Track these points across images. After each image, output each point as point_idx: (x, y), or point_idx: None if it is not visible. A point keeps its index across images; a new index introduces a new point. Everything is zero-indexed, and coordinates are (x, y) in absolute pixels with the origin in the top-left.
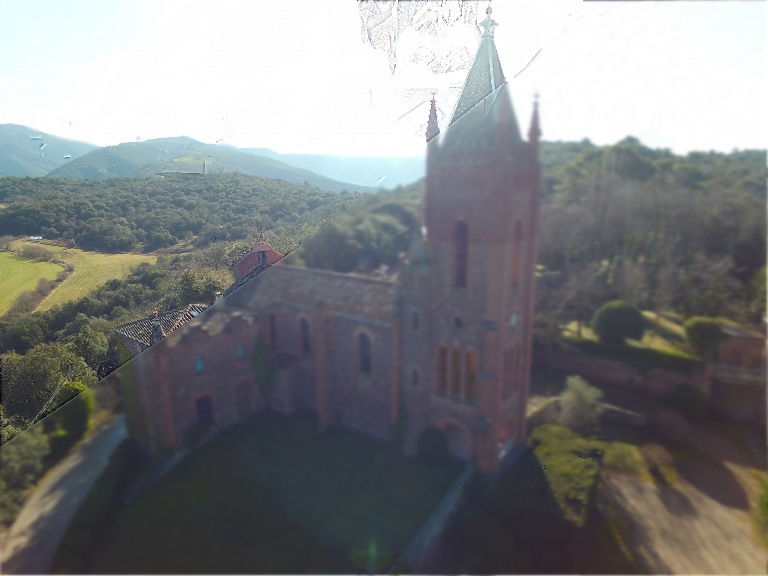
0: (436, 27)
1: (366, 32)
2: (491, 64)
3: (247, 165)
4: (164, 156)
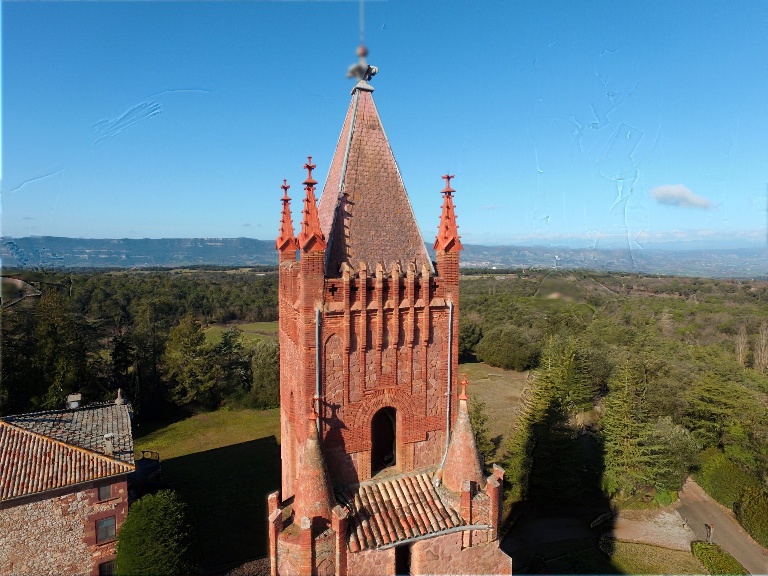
0: None
1: None
2: None
3: None
4: None
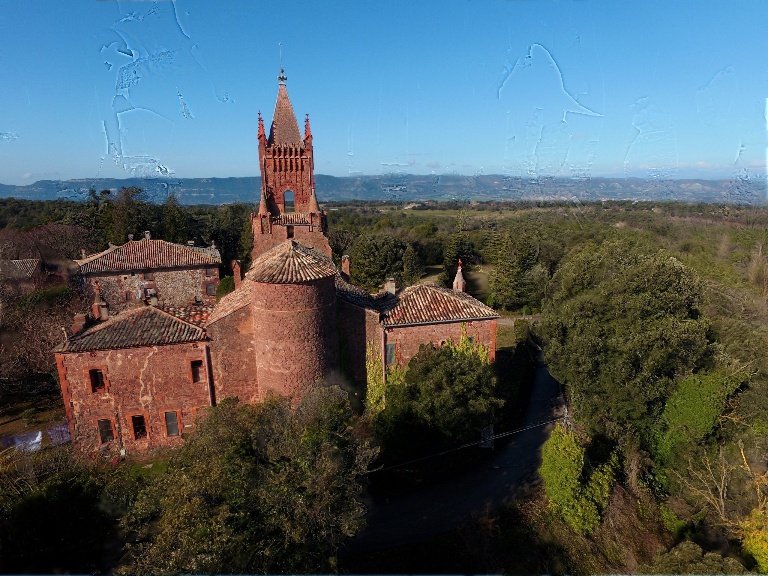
0: None
1: None
2: None
3: None
4: None
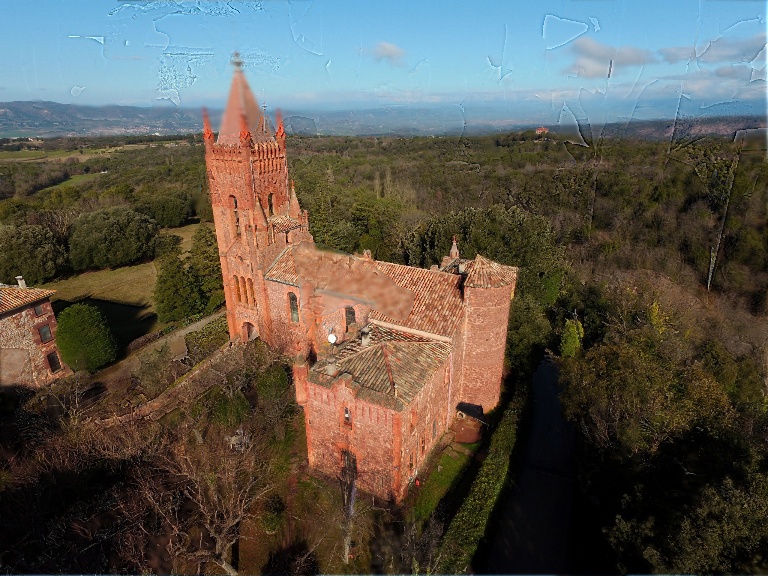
0: None
1: None
2: None
3: None
4: None
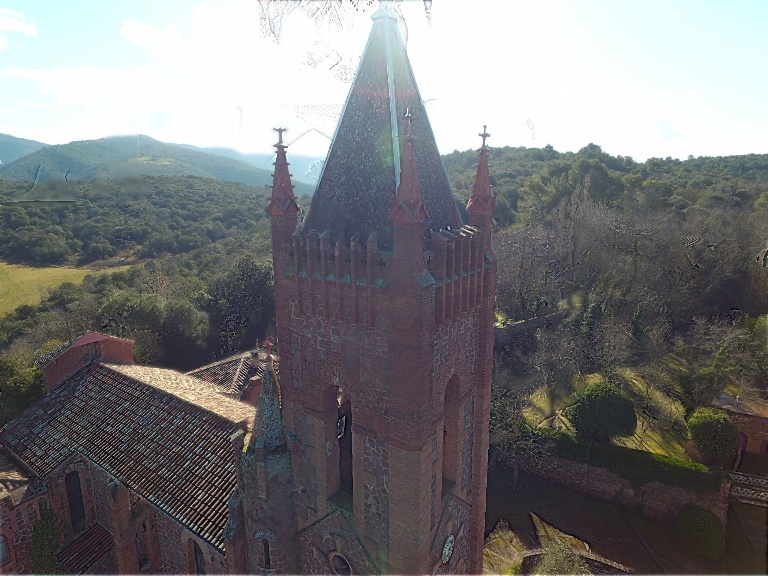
0: (339, 12)
1: (267, 22)
2: (390, 75)
3: (152, 184)
4: (30, 176)
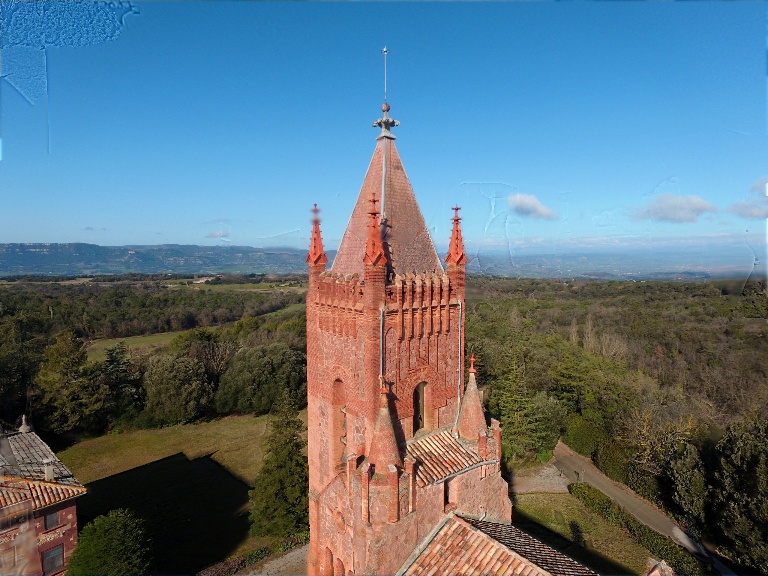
0: None
1: None
2: None
3: None
4: None
